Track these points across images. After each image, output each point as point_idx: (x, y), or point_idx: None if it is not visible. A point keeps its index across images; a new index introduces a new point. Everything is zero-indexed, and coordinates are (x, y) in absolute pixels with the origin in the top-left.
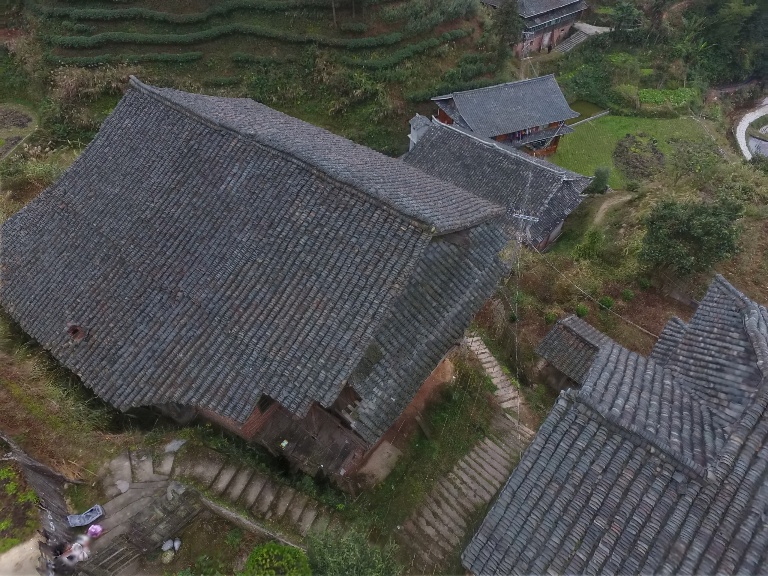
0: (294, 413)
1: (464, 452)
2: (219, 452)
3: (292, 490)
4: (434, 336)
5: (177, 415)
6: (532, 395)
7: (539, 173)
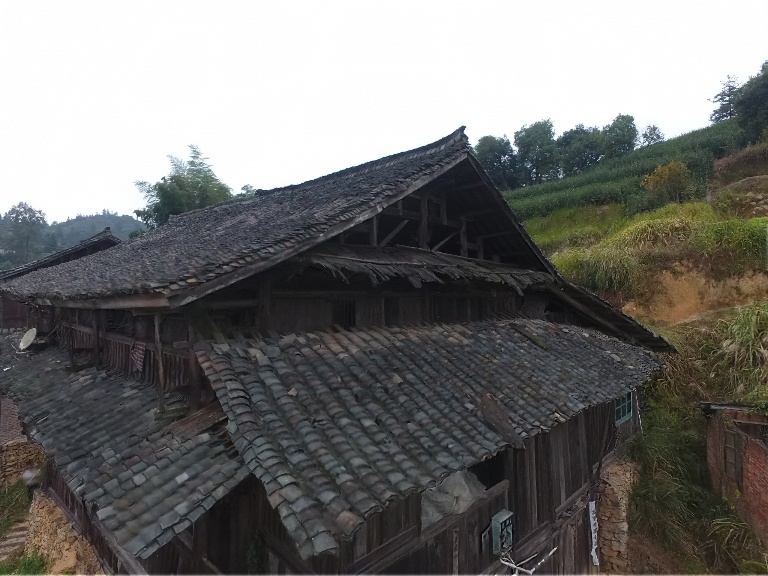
0: None
1: None
2: None
3: None
4: None
5: None
6: None
7: None
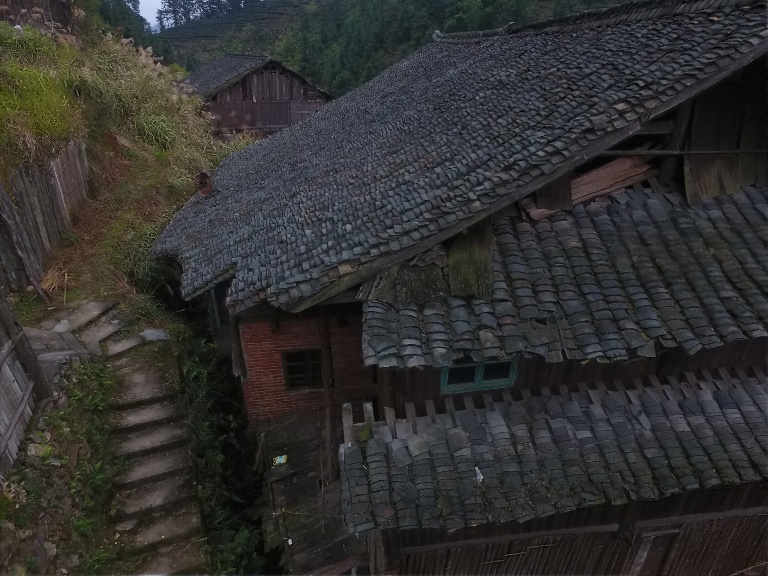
0: (229, 296)
1: None
2: (181, 378)
3: (196, 521)
4: (690, 426)
5: (213, 329)
6: None
7: None
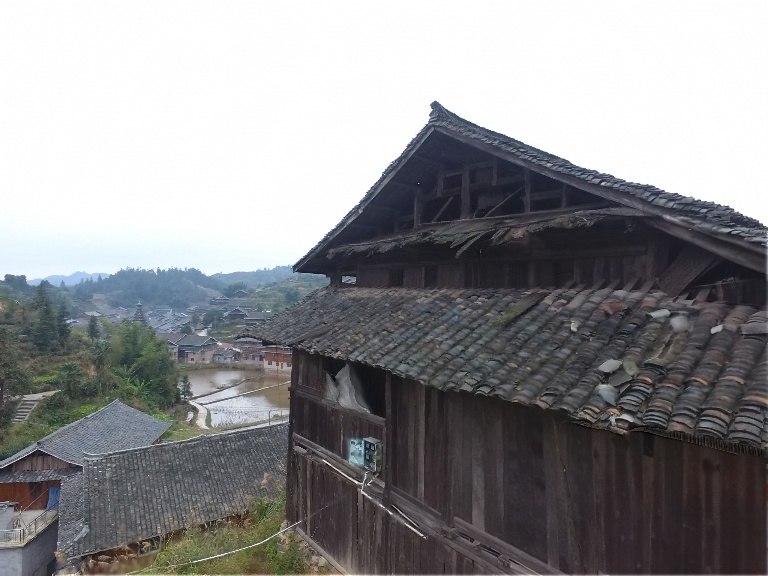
0: None
1: None
2: None
3: None
4: None
5: None
6: None
7: (271, 433)
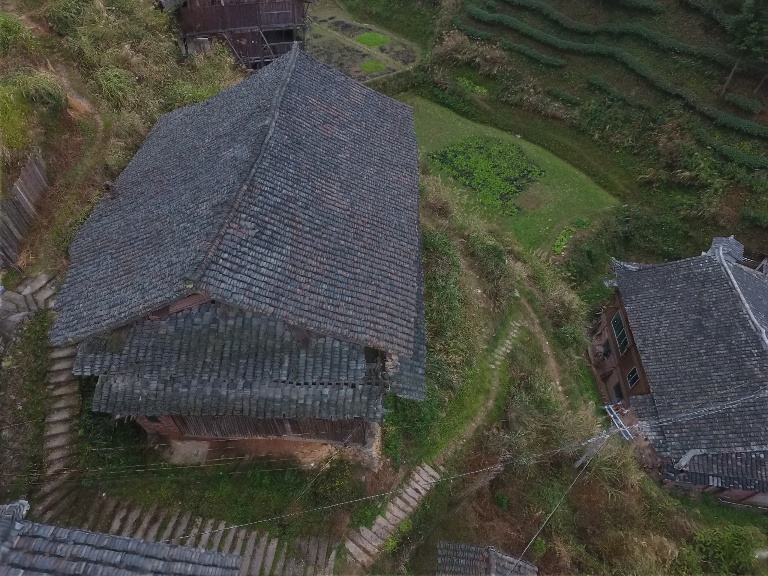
0: None
1: (238, 522)
2: None
3: (76, 389)
4: (227, 393)
5: None
6: (383, 571)
7: None
